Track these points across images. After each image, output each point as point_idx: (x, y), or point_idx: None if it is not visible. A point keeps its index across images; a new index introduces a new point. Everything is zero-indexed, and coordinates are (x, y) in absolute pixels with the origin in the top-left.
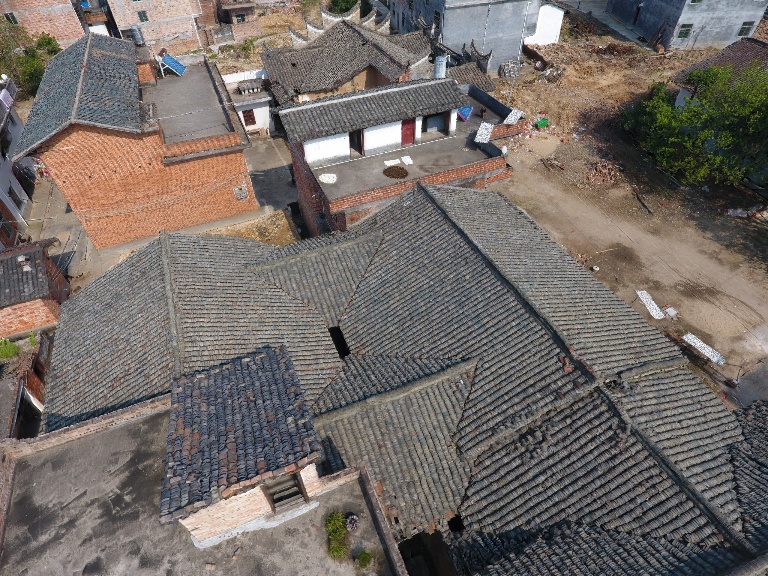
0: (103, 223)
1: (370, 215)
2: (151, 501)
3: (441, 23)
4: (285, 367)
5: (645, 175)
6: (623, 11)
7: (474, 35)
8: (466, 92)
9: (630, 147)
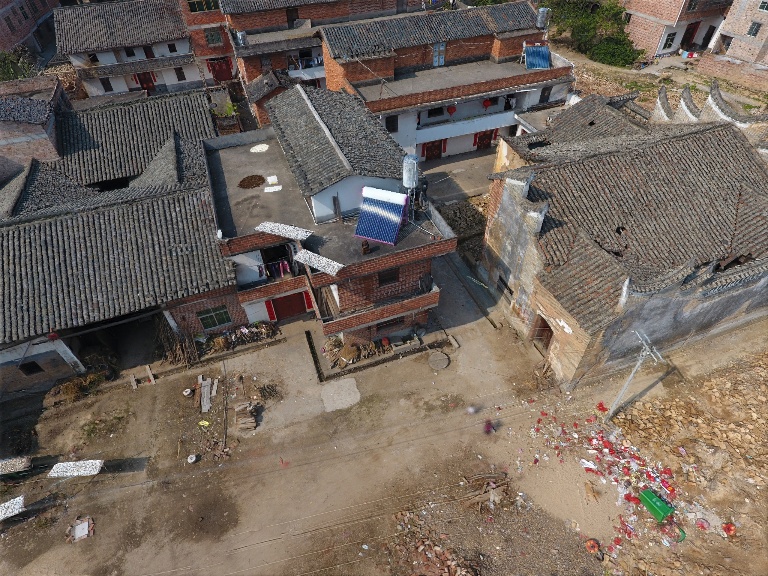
0: None
1: None
2: None
3: None
4: None
5: None
6: None
7: None
8: None
9: None
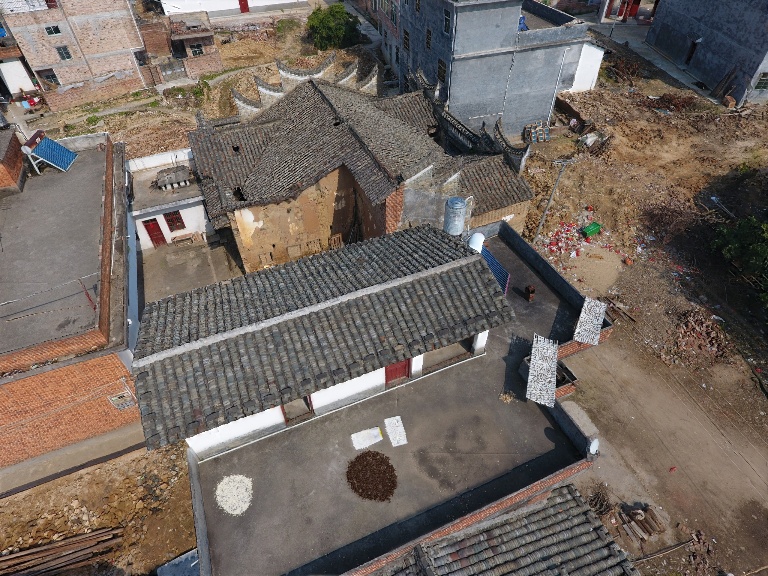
0: None
1: None
2: None
3: (447, 77)
4: None
5: (762, 337)
6: (671, 45)
7: (492, 92)
8: (495, 232)
9: (726, 276)
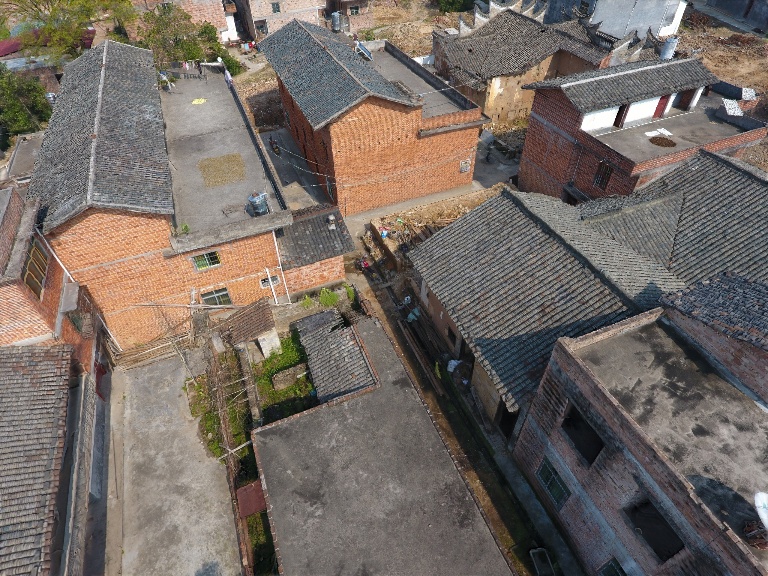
0: (353, 192)
1: (656, 179)
2: (703, 386)
3: None
4: (760, 285)
5: None
6: (731, 4)
7: (618, 25)
8: None
9: None
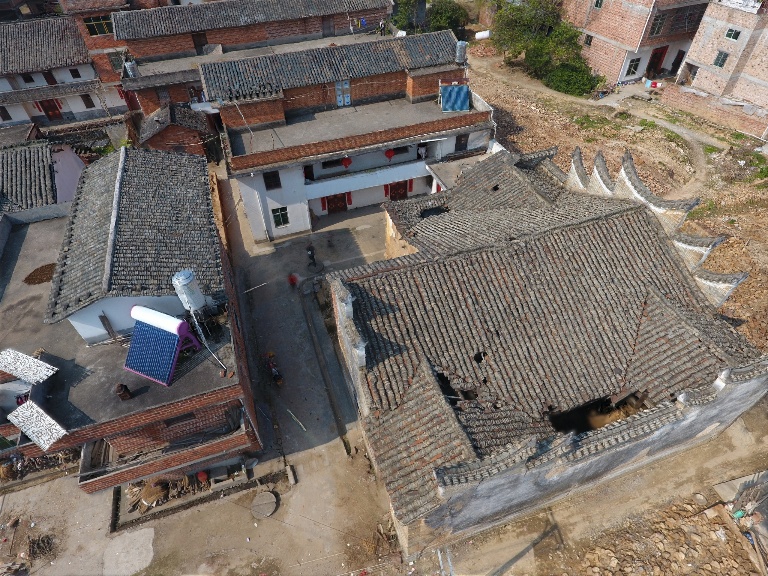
0: None
1: None
2: None
3: None
4: None
5: None
6: None
7: None
8: None
9: None
